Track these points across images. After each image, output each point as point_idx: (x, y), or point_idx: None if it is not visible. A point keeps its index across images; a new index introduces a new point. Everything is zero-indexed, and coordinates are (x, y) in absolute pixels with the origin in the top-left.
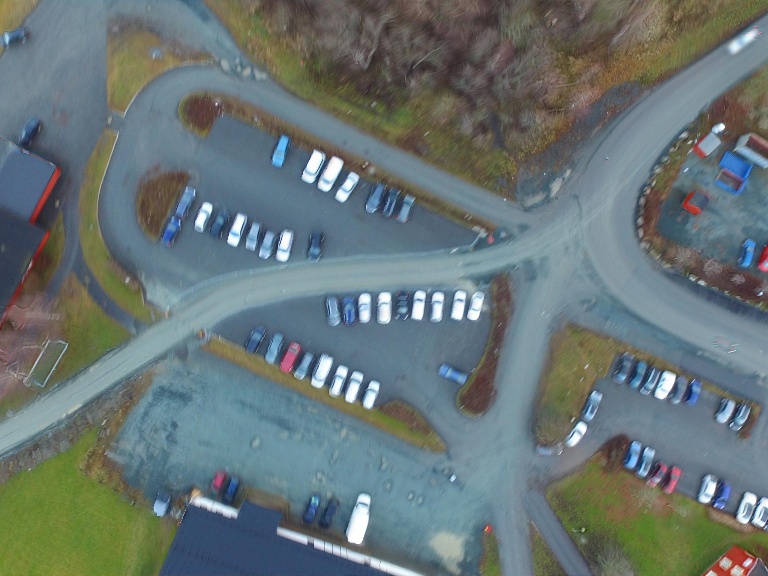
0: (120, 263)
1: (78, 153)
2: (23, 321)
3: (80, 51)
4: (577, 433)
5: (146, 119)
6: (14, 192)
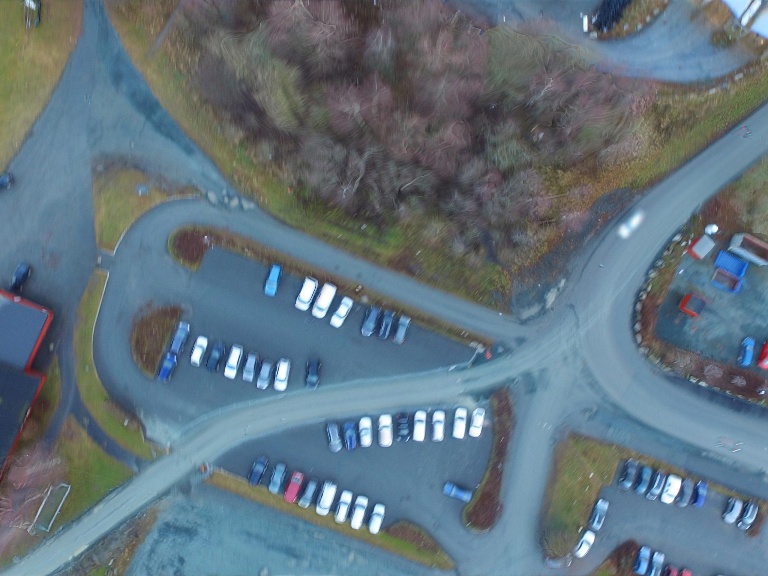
0: (118, 402)
1: (70, 294)
2: (24, 480)
3: (66, 192)
4: (585, 543)
5: (136, 256)
6: (8, 343)
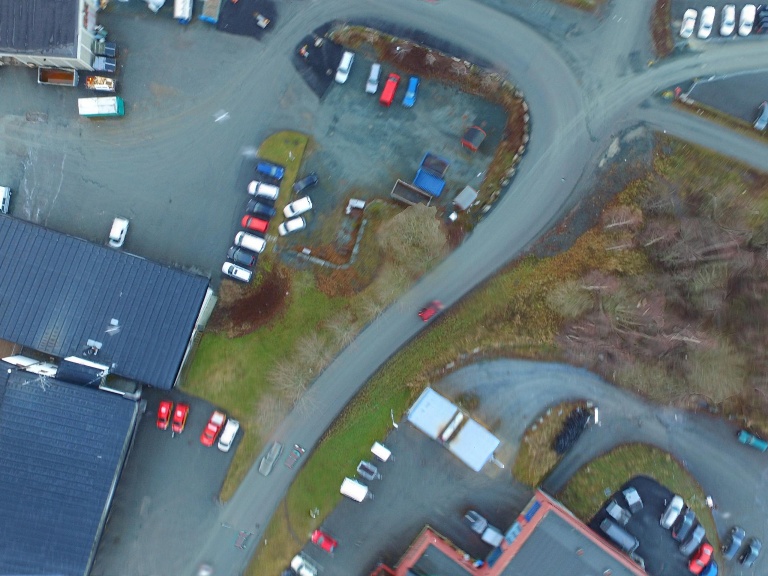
0: None
1: None
2: None
3: None
4: None
5: None
6: None
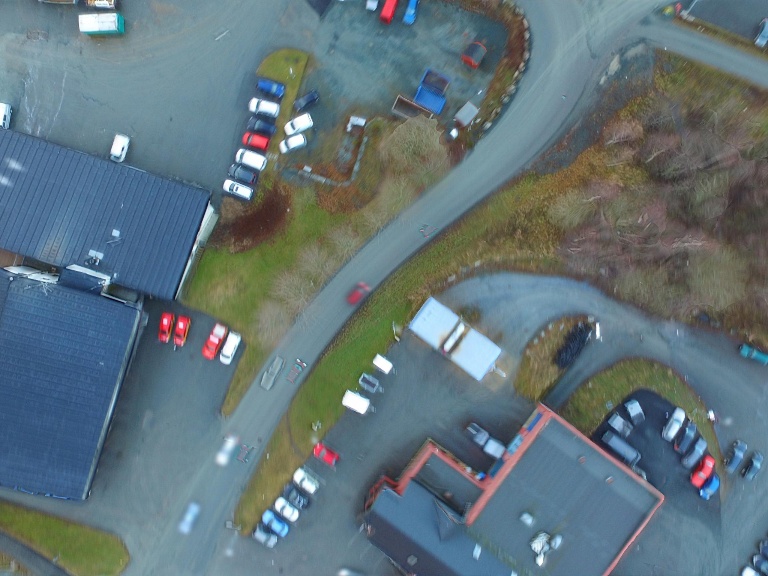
0: None
1: None
2: None
3: None
4: None
5: None
6: None
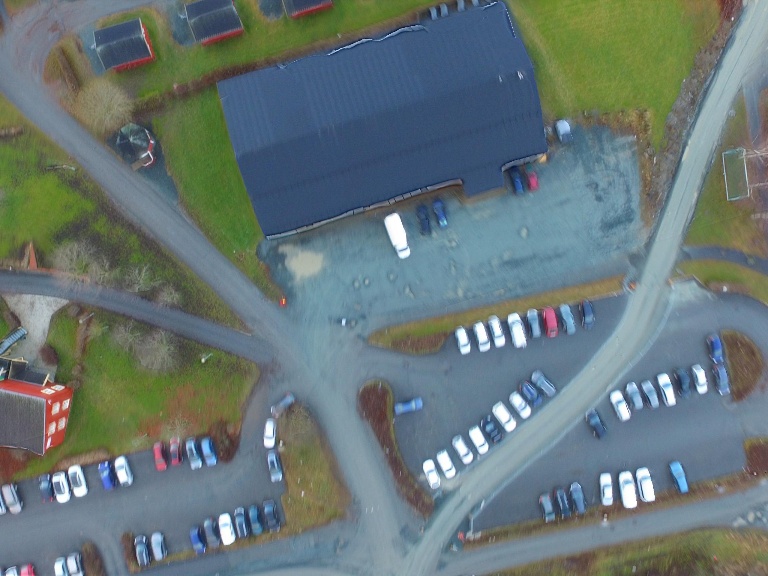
0: (737, 294)
1: None
2: None
3: None
4: (271, 436)
5: None
6: None
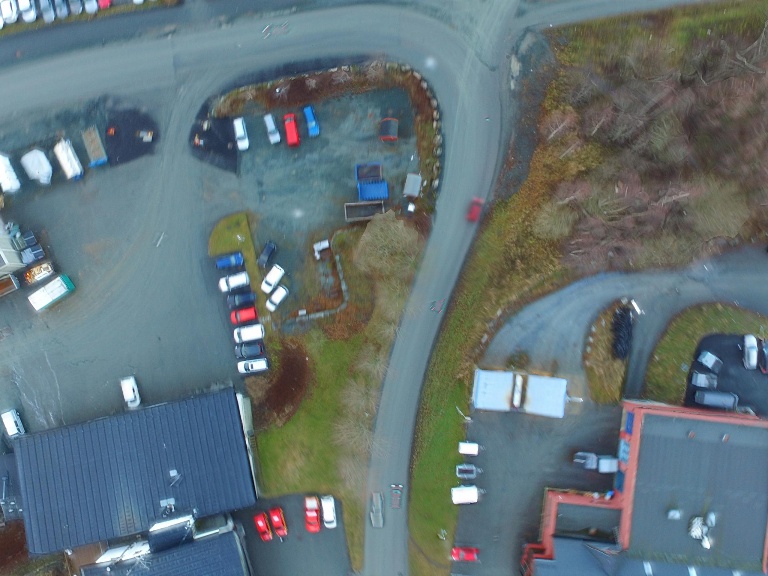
0: None
1: None
2: None
3: None
4: None
5: None
6: None
